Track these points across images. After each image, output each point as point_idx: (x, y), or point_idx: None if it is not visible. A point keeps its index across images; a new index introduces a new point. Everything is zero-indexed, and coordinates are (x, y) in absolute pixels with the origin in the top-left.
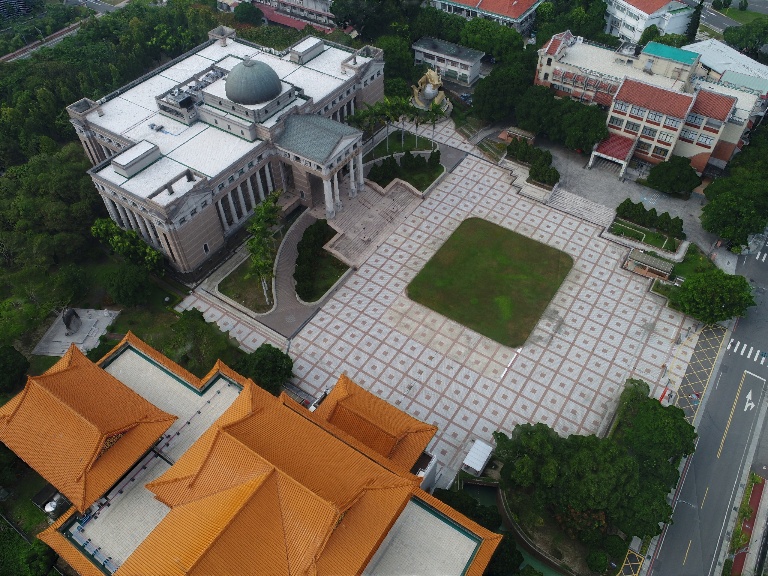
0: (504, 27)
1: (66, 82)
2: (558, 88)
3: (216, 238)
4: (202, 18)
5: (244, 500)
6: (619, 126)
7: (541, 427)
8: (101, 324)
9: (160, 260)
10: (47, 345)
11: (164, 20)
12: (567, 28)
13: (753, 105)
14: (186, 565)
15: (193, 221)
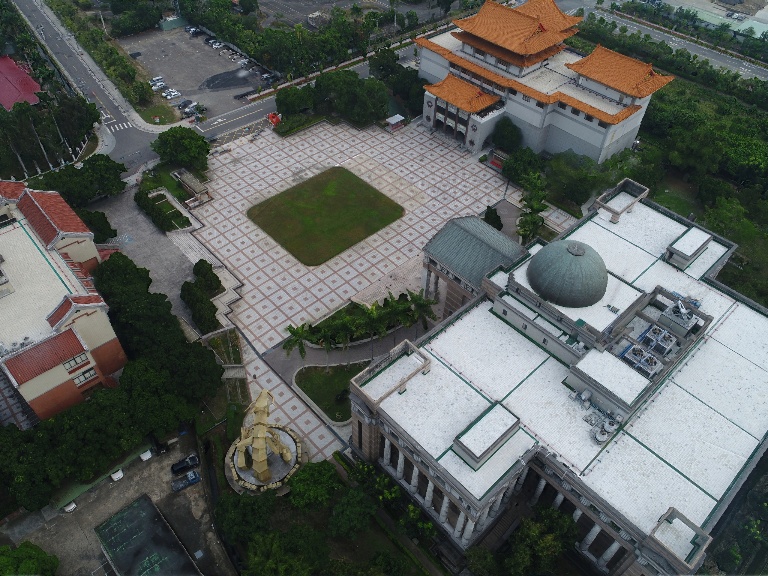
0: None
1: None
2: None
3: None
4: None
5: None
6: None
7: None
8: None
9: None
10: None
11: None
12: None
13: None
14: None
15: None
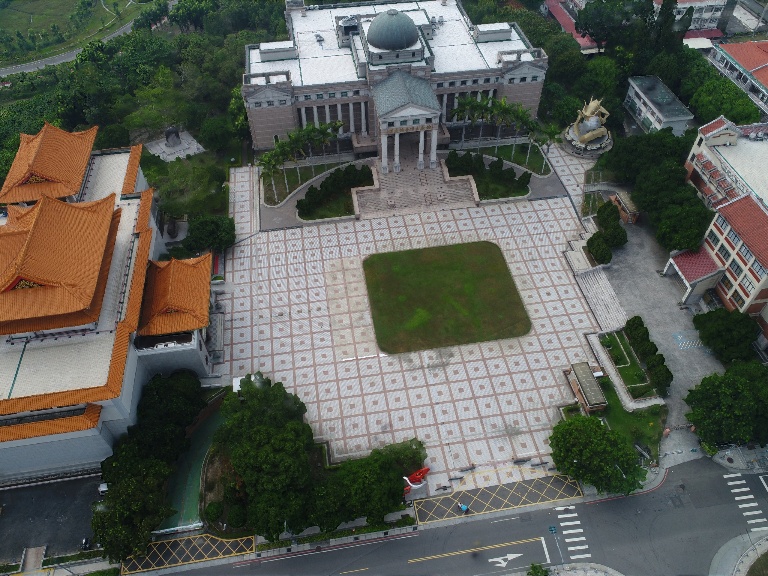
0: (743, 100)
1: None
2: None
3: None
4: None
5: None
6: (714, 245)
7: (275, 390)
8: (189, 151)
9: (243, 129)
10: (154, 145)
11: None
12: None
13: None
14: None
15: (268, 110)
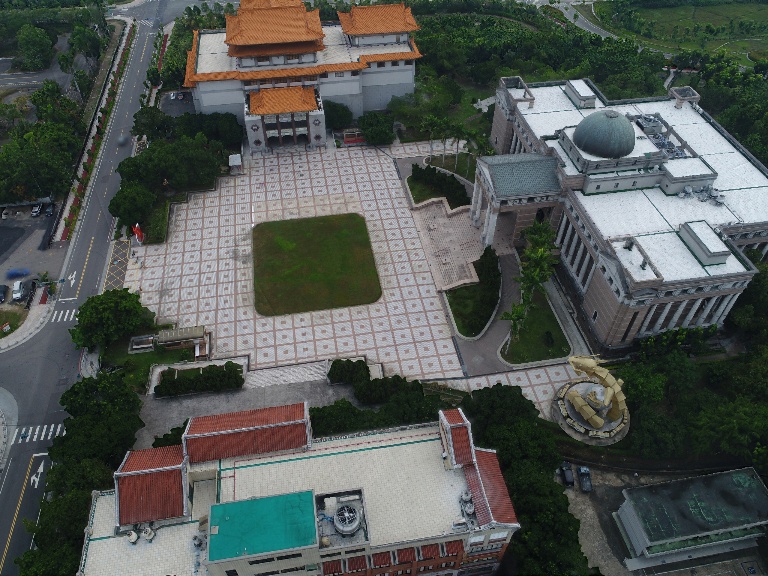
0: None
1: None
2: None
3: None
4: None
5: (273, 4)
6: None
7: None
8: None
9: None
10: None
11: None
12: None
13: (86, 567)
14: None
15: None
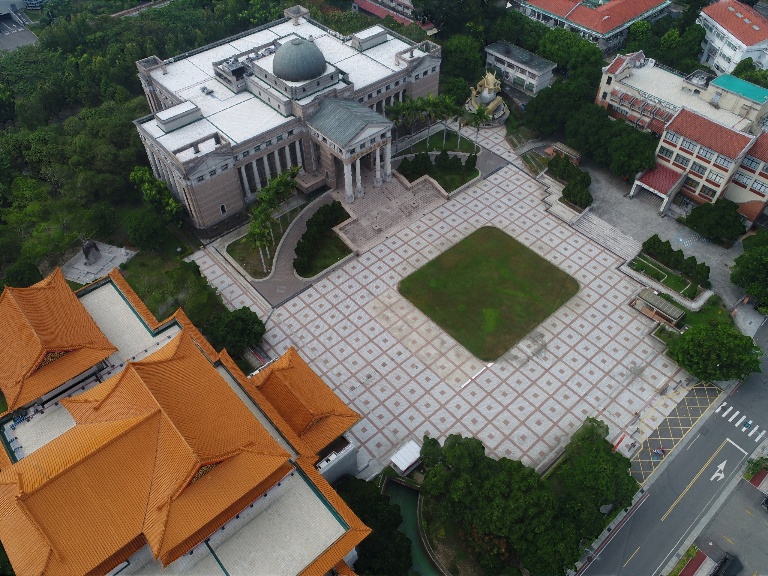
0: (584, 41)
1: (154, 41)
2: (616, 109)
3: (235, 202)
4: None
5: None
6: (668, 158)
7: (468, 441)
8: (117, 261)
9: (179, 212)
10: (67, 270)
11: None
12: (652, 50)
13: None
14: (56, 473)
15: (211, 181)
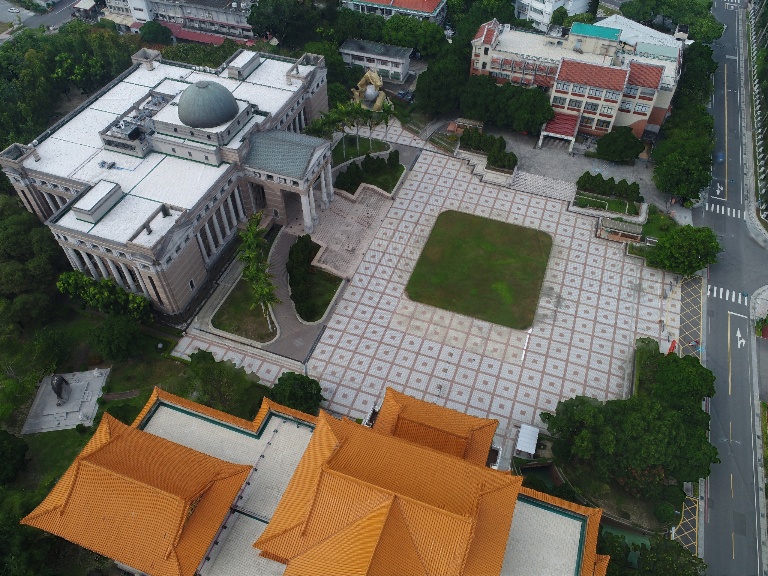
0: (425, 22)
1: None
2: (496, 75)
3: (200, 272)
4: (109, 42)
5: (375, 534)
6: (562, 105)
7: (586, 399)
8: (93, 386)
9: (146, 306)
10: (37, 421)
11: (64, 49)
12: (484, 17)
13: (674, 71)
14: None
15: (178, 258)
